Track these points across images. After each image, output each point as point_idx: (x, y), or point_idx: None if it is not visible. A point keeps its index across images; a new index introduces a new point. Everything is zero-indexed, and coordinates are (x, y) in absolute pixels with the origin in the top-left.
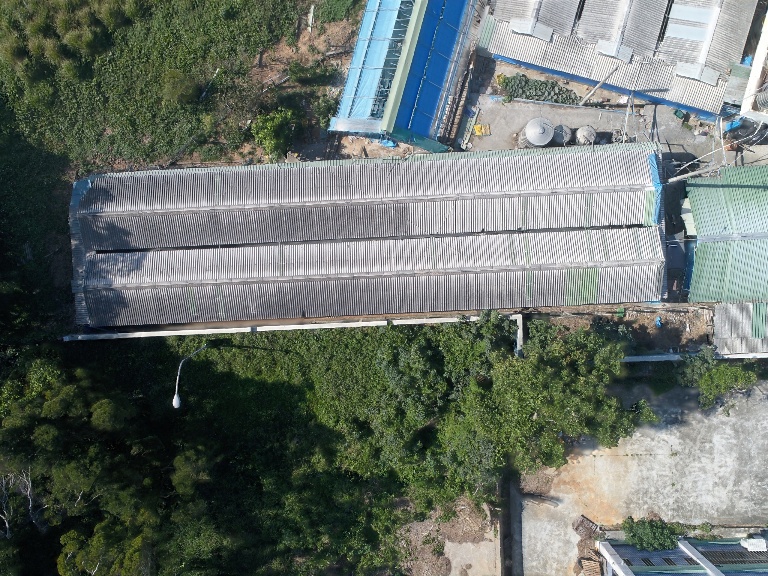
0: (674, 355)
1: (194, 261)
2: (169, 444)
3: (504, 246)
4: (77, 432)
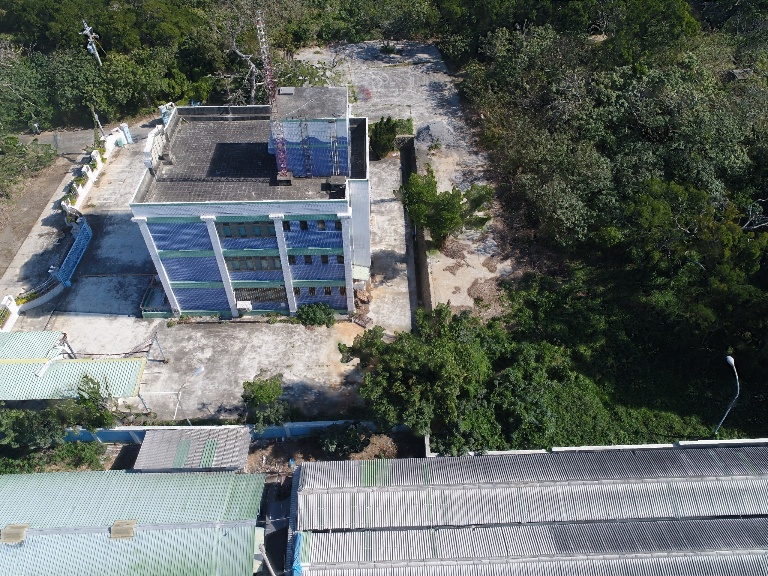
0: (288, 427)
1: (762, 501)
2: None
3: (452, 511)
4: None
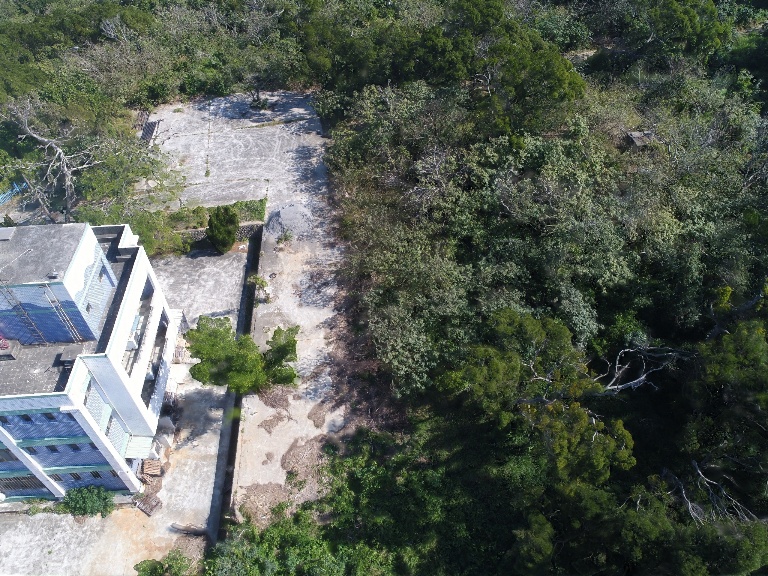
0: None
1: None
2: (572, 569)
3: None
4: (666, 575)
